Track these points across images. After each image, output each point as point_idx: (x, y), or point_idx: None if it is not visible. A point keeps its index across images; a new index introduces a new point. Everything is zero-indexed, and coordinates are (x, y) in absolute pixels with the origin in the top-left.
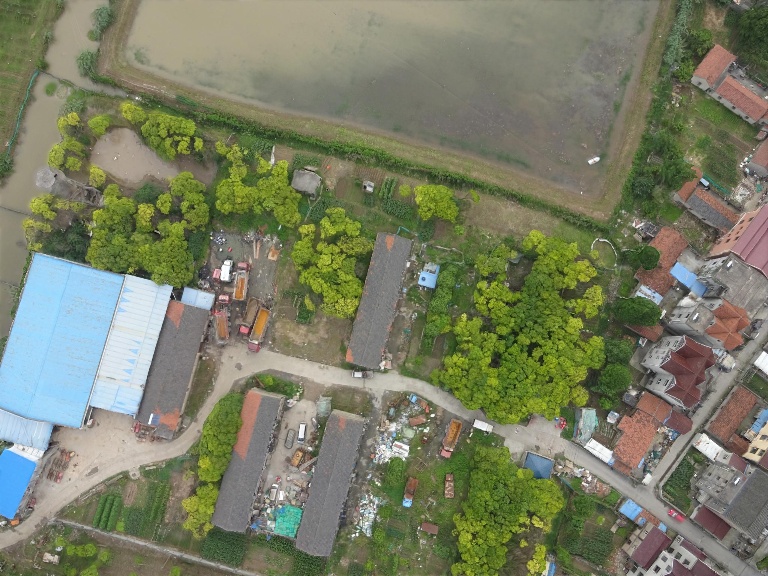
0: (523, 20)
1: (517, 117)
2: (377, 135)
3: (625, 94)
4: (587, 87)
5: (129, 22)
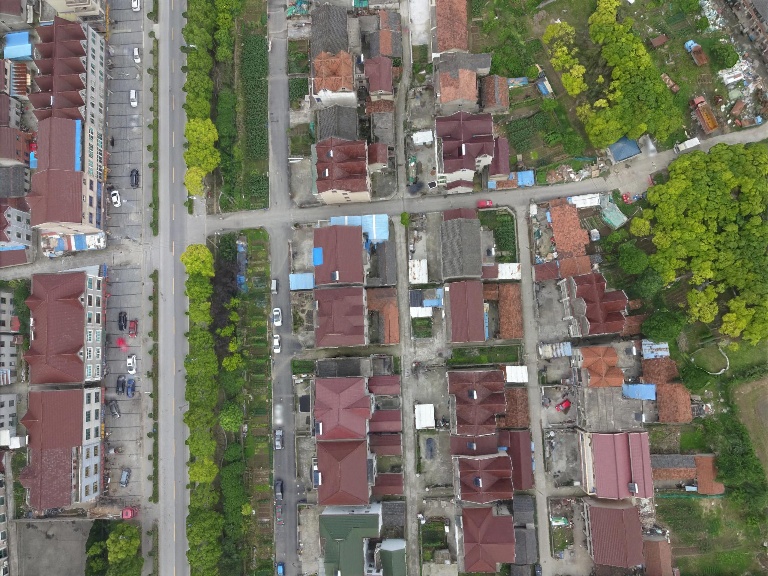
0: None
1: None
2: None
3: None
4: None
5: None
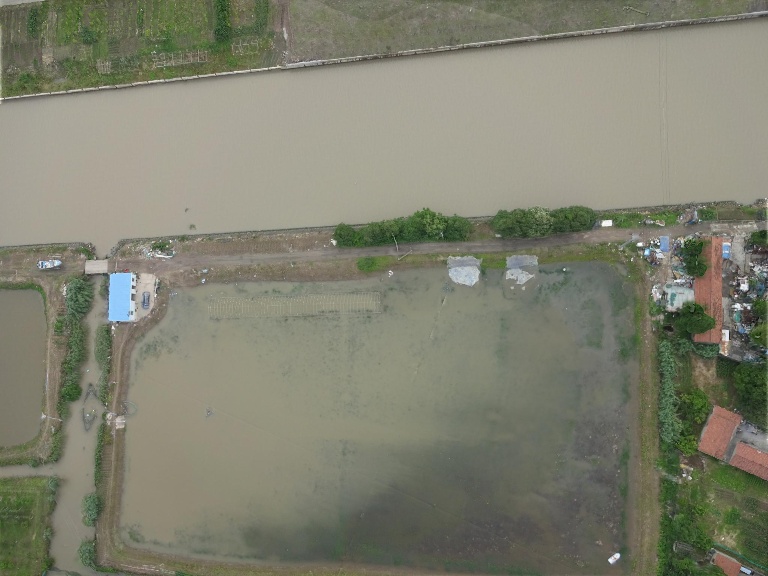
0: (498, 415)
1: (518, 524)
2: (379, 575)
3: (628, 474)
4: (585, 475)
5: (117, 502)
